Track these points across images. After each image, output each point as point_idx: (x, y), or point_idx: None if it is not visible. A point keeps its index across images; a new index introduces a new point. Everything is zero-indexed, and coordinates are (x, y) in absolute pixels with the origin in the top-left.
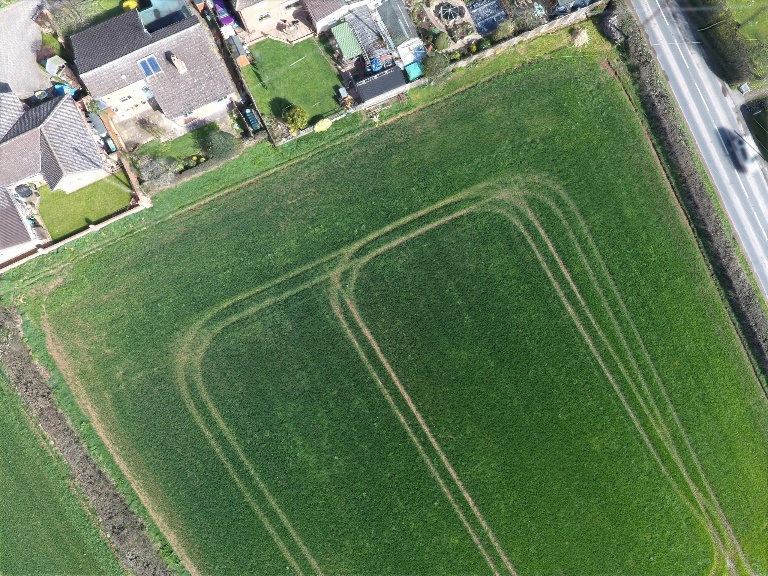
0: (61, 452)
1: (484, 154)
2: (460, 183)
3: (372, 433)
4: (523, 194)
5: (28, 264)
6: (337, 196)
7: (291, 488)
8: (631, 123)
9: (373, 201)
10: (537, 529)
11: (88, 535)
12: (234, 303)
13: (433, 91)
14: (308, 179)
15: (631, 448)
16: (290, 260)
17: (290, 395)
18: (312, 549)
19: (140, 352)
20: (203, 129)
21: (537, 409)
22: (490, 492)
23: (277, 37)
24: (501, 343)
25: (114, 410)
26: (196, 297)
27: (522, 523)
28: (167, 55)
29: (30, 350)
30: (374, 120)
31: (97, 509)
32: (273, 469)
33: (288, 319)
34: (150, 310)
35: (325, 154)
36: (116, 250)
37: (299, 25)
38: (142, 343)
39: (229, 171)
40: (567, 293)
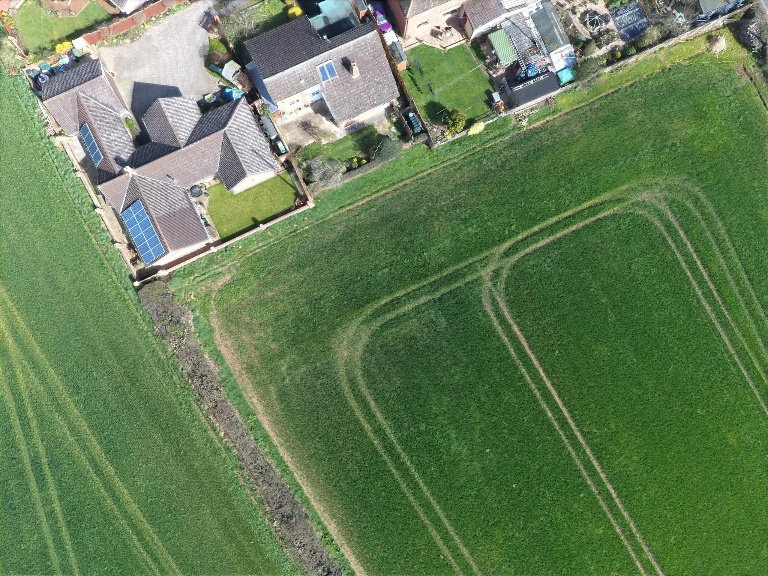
0: (233, 443)
1: (627, 157)
2: (605, 185)
3: (522, 427)
4: (663, 196)
5: (198, 262)
6: (488, 197)
7: (445, 479)
8: (766, 127)
9: (523, 202)
10: (677, 520)
11: (255, 524)
12: (392, 300)
13: (578, 96)
14: (460, 180)
15: (766, 442)
16: (444, 259)
17: (445, 389)
18: (465, 538)
19: (303, 347)
20: (362, 132)
21: (677, 404)
22: (633, 484)
23: (431, 43)
24: (643, 340)
25: (279, 403)
26: (356, 294)
27: (663, 514)
28: (343, 61)
29: (201, 345)
30: (522, 124)
31: (267, 498)
32: (428, 461)
33: (443, 316)
34: (313, 307)
35: (476, 156)
36: (280, 248)
37: (452, 31)
38: (306, 338)
39: (386, 172)
40: (705, 292)
